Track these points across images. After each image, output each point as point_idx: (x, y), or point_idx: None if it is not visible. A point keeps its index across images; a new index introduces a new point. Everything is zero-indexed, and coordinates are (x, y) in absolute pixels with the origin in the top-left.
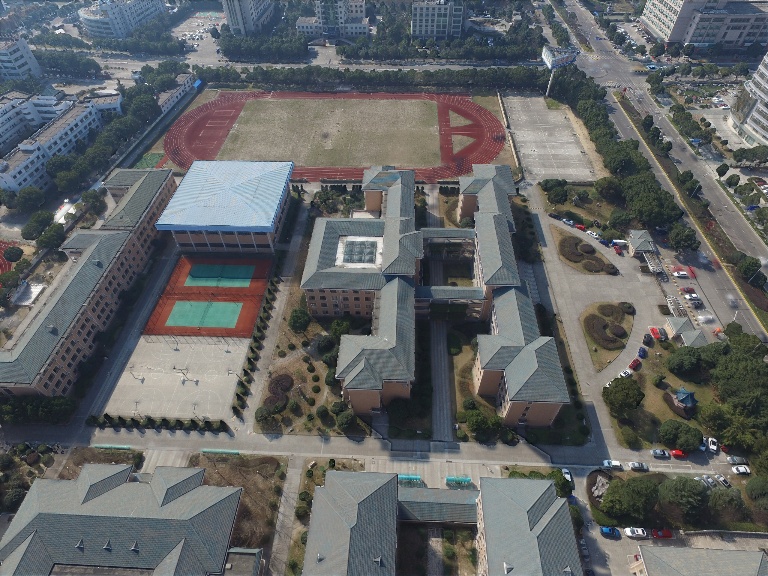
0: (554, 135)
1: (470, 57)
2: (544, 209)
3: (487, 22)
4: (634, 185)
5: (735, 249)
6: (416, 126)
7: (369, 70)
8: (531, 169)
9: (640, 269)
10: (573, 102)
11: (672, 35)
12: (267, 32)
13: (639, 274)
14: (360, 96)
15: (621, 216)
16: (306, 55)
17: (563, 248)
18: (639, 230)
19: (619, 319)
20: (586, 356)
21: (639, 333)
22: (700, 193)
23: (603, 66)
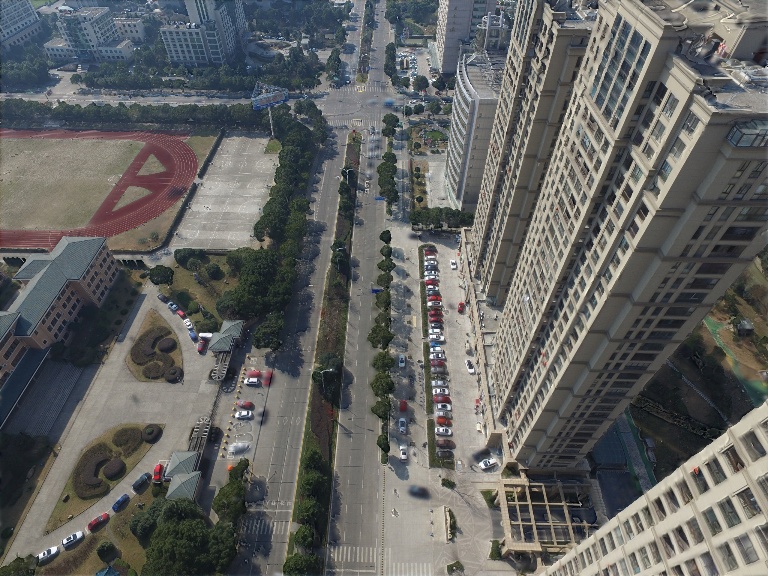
0: (245, 187)
1: (224, 87)
2: (159, 288)
3: (275, 45)
4: (246, 263)
5: (342, 343)
6: (97, 174)
7: (101, 102)
8: (185, 232)
9: (208, 374)
10: (282, 147)
11: (444, 66)
12: (17, 54)
13: (204, 381)
14: (64, 135)
15: (222, 302)
16: (44, 82)
17: (138, 344)
18: (232, 321)
19: (129, 450)
20: (48, 509)
21: (140, 471)
22: (355, 265)
23: (362, 100)
